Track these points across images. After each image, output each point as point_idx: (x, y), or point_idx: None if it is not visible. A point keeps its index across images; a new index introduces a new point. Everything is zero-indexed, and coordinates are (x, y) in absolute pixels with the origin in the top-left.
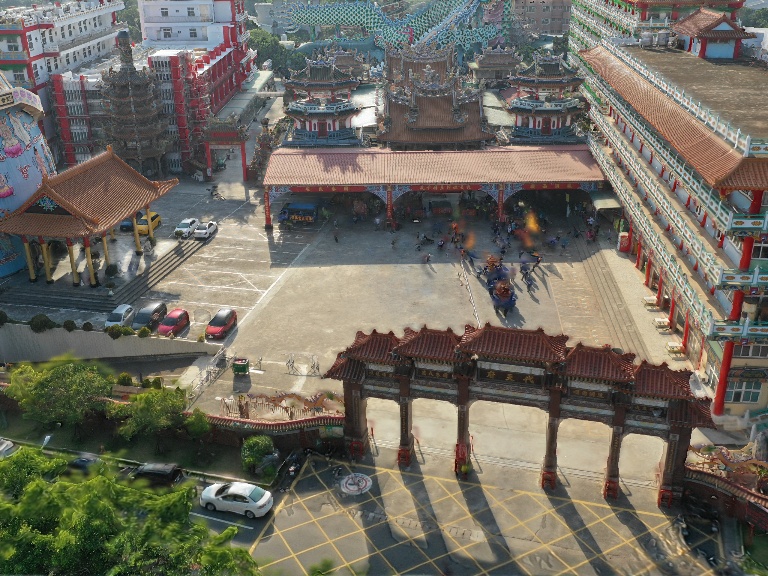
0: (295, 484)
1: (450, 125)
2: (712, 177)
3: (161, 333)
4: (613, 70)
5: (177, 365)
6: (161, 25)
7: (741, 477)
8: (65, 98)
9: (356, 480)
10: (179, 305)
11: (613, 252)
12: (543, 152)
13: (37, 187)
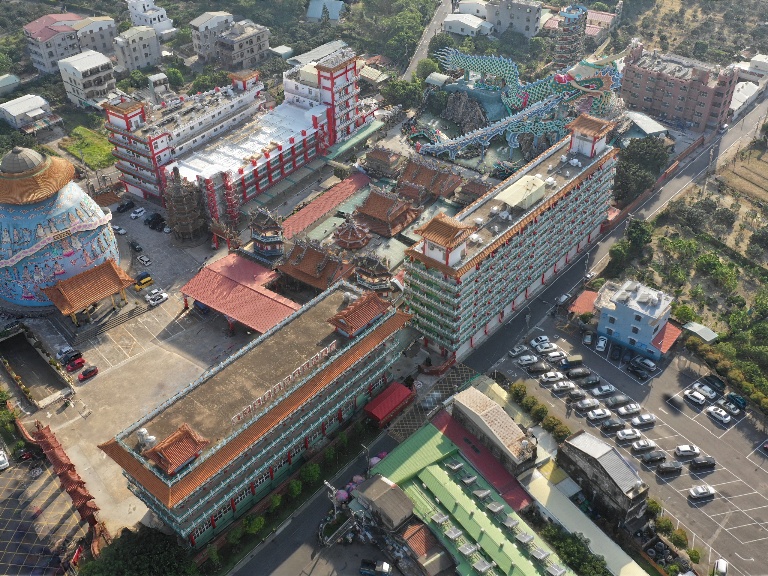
0: (23, 463)
1: (312, 274)
2: (108, 441)
3: (67, 369)
4: None
5: (59, 387)
6: (294, 95)
7: (115, 537)
8: (166, 179)
9: (34, 471)
10: (94, 352)
11: None
12: None
13: (81, 267)
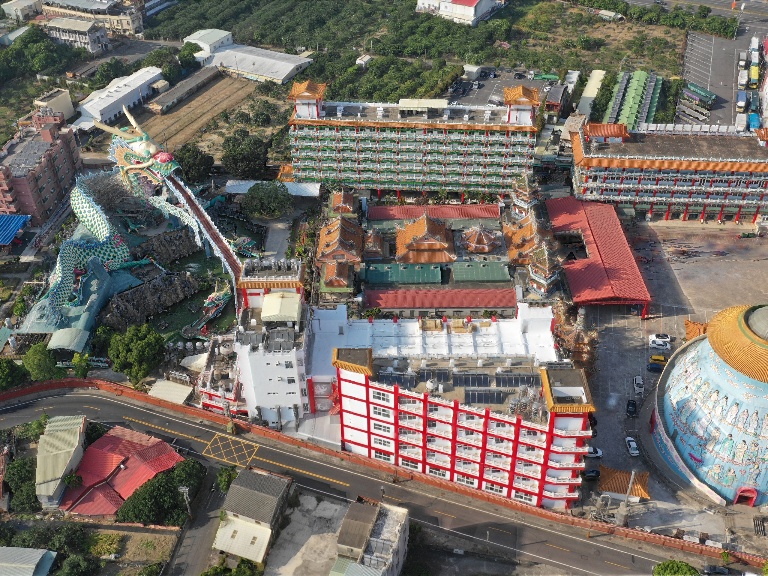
0: None
1: None
2: None
3: None
4: (646, 164)
5: None
6: None
7: None
8: None
9: None
10: None
11: (652, 223)
12: (587, 213)
13: None
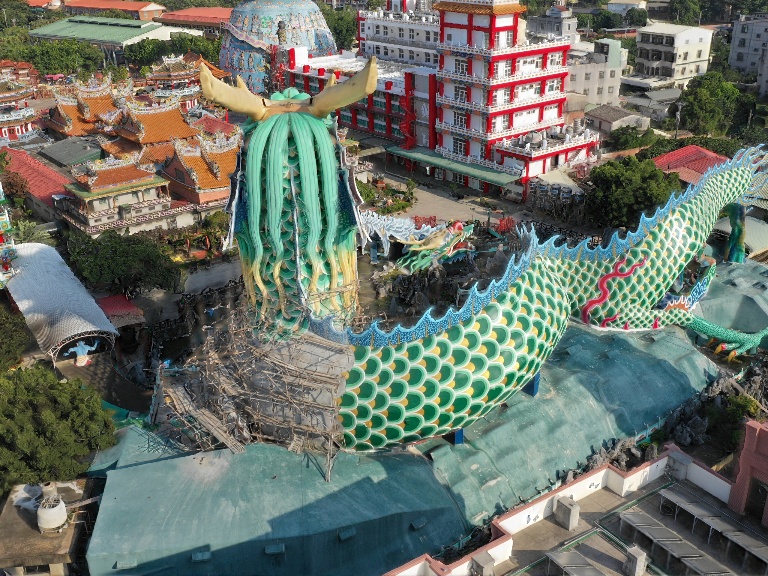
0: None
1: None
2: None
3: None
4: None
5: None
6: None
7: None
8: None
9: None
10: None
11: None
12: None
13: None
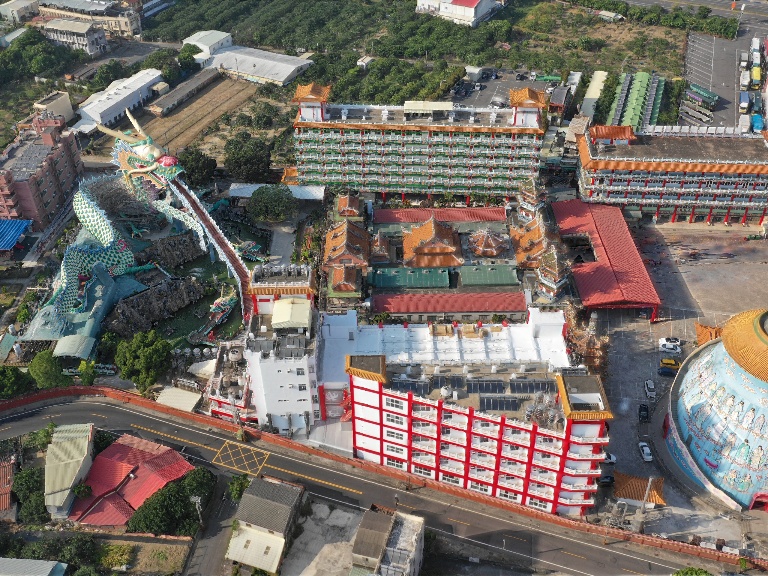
0: None
1: None
2: None
3: None
4: (653, 166)
5: None
6: None
7: None
8: None
9: None
10: None
11: (658, 225)
12: (594, 216)
13: None
